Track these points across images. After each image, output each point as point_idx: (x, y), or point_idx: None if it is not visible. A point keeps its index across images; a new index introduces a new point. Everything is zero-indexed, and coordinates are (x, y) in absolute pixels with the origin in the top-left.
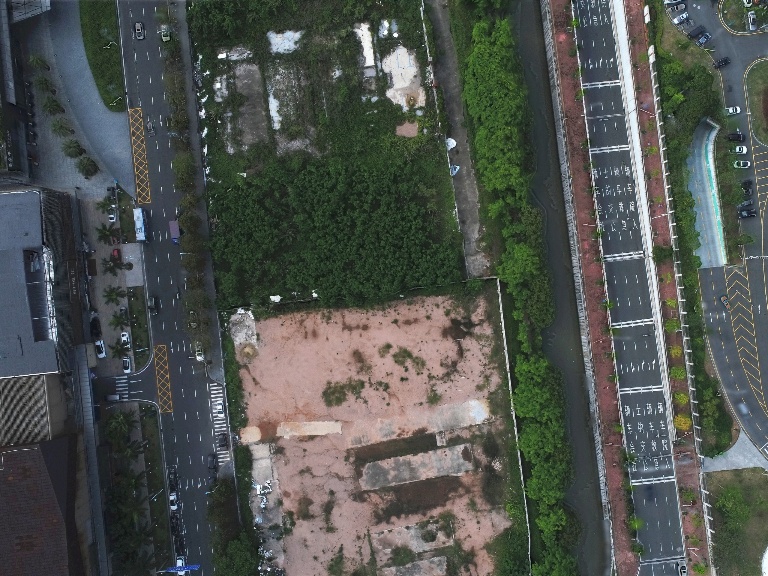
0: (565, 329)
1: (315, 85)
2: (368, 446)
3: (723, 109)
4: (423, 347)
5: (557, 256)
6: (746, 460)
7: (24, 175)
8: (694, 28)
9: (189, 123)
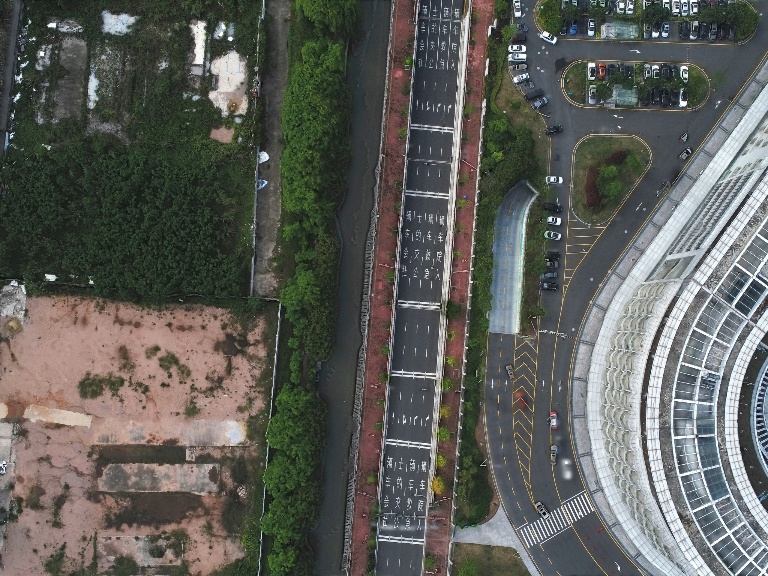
0: (343, 367)
1: (138, 72)
2: (114, 446)
3: (542, 176)
4: (192, 356)
5: (348, 291)
6: (499, 538)
7: None
8: (533, 90)
9: (4, 85)
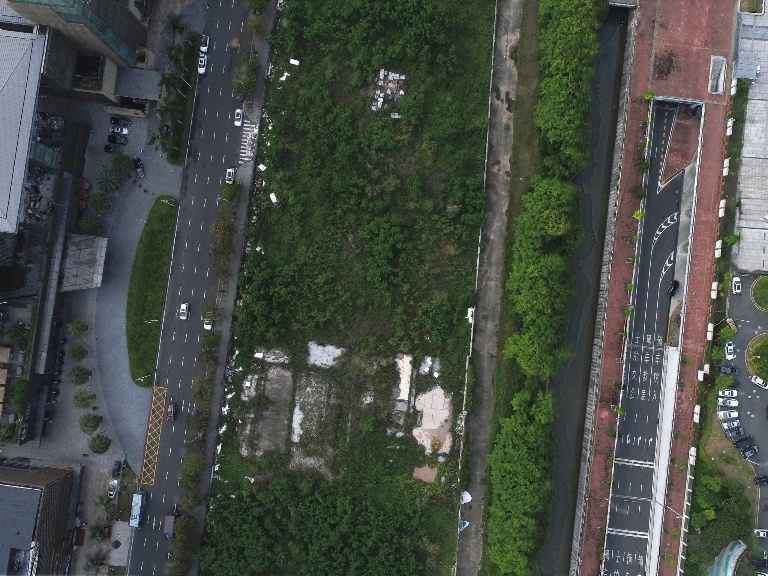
0: None
1: (343, 408)
2: None
3: (753, 534)
4: None
5: None
6: None
7: (35, 444)
8: (743, 437)
9: (210, 415)
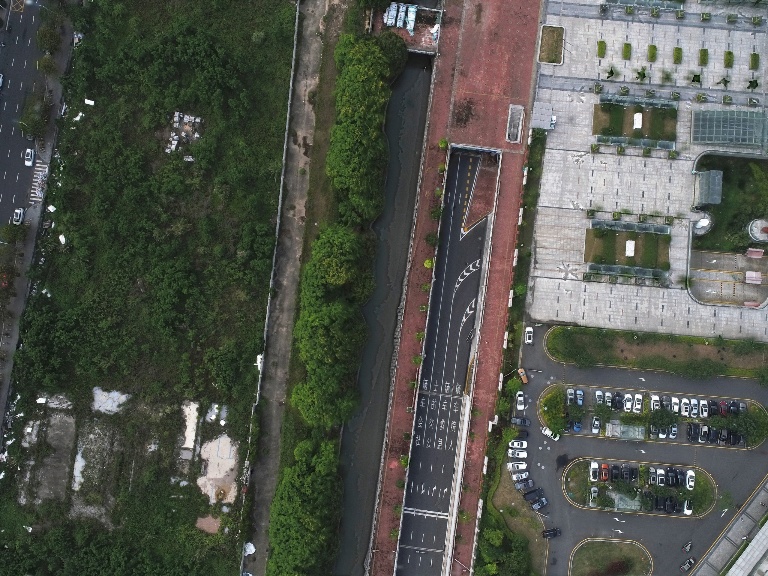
0: None
1: (125, 456)
2: None
3: None
4: None
5: None
6: None
7: None
8: (532, 489)
9: None
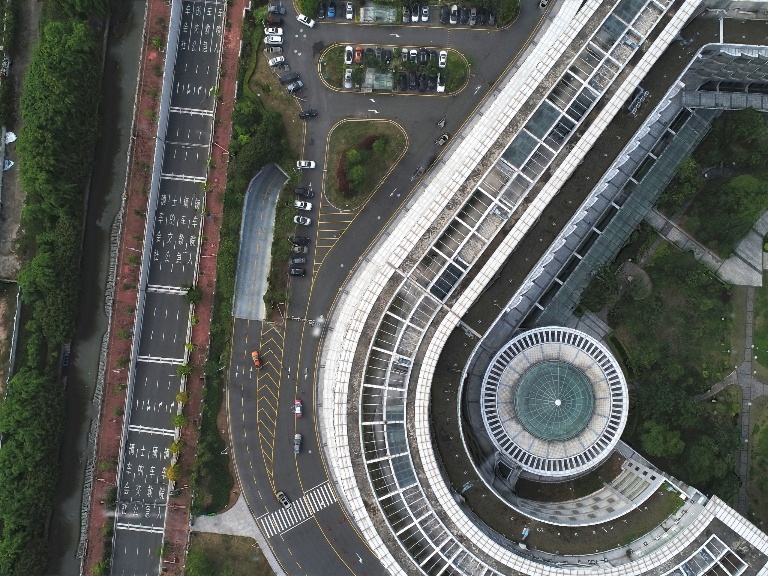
0: (88, 351)
1: None
2: None
3: (290, 160)
4: None
5: (92, 274)
6: (239, 527)
7: None
8: None
9: None
